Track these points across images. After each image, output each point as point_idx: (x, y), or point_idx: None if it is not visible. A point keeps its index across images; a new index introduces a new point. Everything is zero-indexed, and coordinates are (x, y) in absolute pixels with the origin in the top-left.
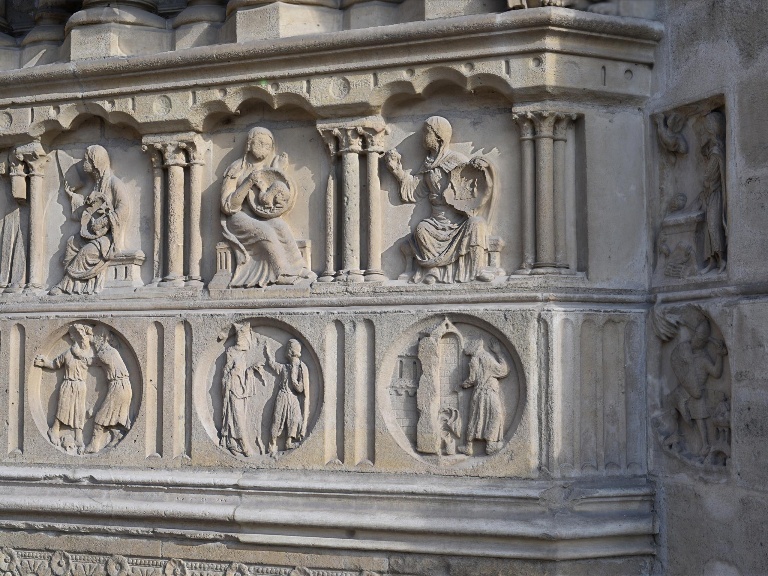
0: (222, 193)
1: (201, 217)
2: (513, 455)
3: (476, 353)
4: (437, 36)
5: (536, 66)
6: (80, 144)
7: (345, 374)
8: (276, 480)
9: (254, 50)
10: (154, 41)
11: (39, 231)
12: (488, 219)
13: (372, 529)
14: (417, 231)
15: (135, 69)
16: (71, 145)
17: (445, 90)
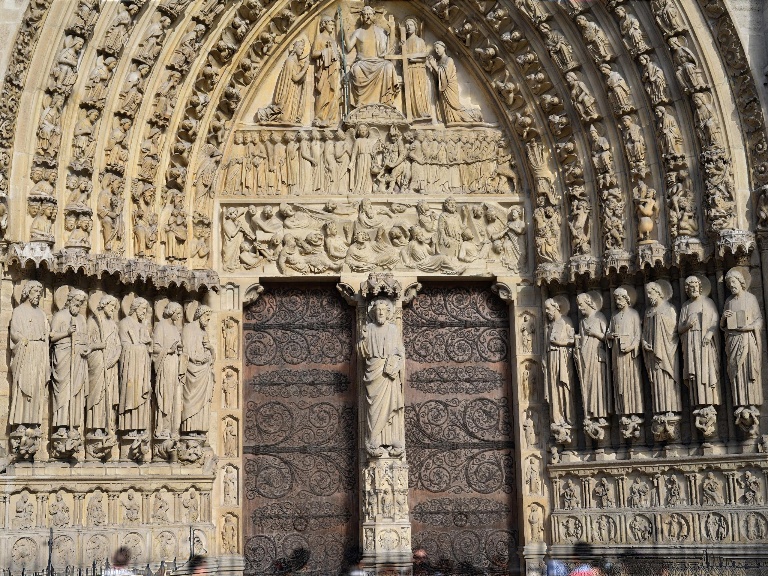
0: (704, 486)
1: (699, 491)
2: (767, 539)
3: (759, 519)
4: (746, 457)
5: (766, 463)
6: (669, 474)
7: (733, 524)
8: (721, 545)
9: (709, 458)
10: (685, 452)
11: (661, 493)
12: (760, 492)
13: (741, 554)
14: (746, 495)
15: (683, 460)
16: (667, 474)
17: (749, 466)
